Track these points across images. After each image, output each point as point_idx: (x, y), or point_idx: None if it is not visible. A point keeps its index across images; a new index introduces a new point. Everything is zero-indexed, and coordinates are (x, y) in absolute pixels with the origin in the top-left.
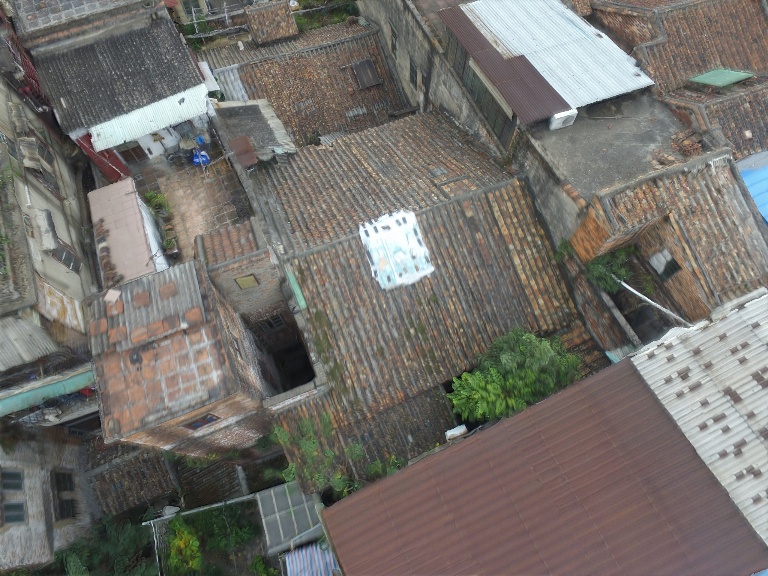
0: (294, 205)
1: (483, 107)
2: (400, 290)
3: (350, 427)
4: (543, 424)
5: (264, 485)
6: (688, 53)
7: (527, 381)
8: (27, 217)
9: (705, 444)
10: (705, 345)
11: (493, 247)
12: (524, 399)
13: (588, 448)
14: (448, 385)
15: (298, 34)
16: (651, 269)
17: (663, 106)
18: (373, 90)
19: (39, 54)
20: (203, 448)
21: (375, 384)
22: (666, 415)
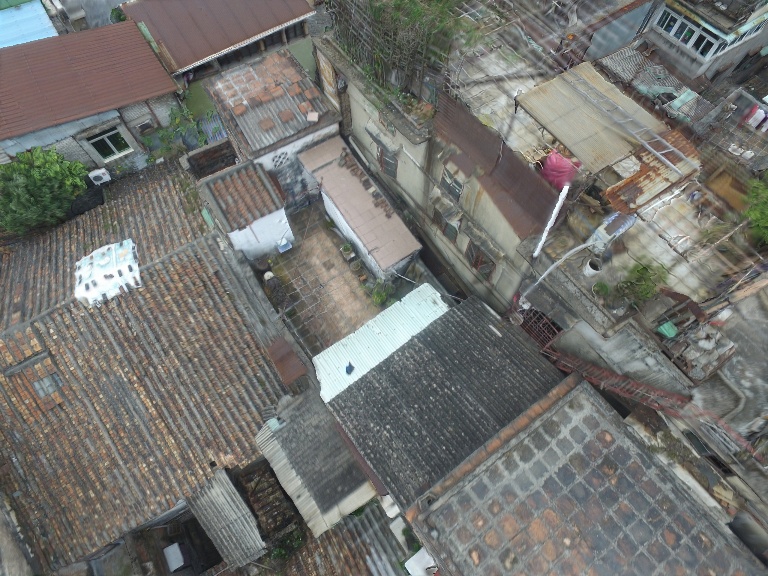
0: (231, 324)
1: None
2: None
3: None
4: (1, 129)
5: None
6: None
7: (8, 164)
8: None
9: None
10: None
11: (8, 296)
12: None
13: None
14: None
15: None
16: None
17: None
18: None
19: None
20: None
21: None
22: None
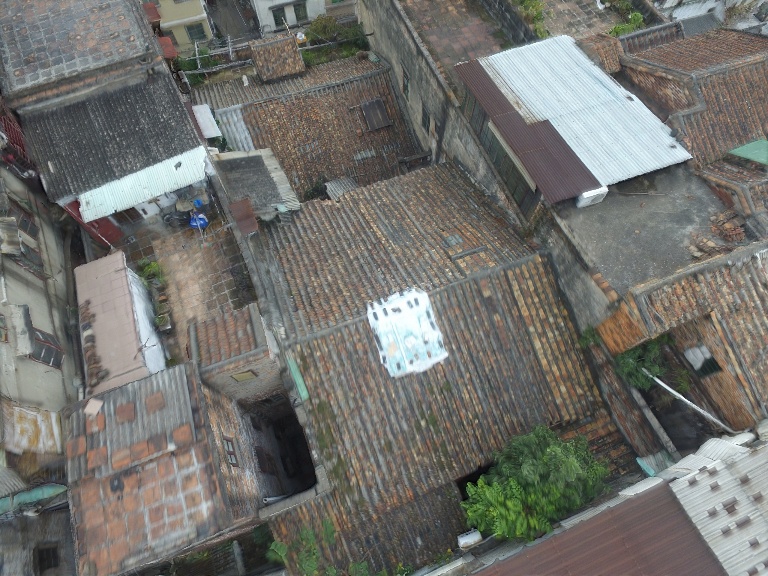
0: (297, 275)
1: (502, 170)
2: (410, 377)
3: (354, 529)
4: (570, 557)
5: (261, 561)
6: (728, 122)
7: (551, 498)
8: (1, 317)
9: None
10: (754, 472)
11: (512, 329)
12: (547, 516)
13: None
14: (461, 481)
15: (305, 70)
16: (686, 362)
17: (701, 181)
18: (383, 132)
19: (26, 113)
20: (194, 549)
21: (382, 482)
22: (710, 555)
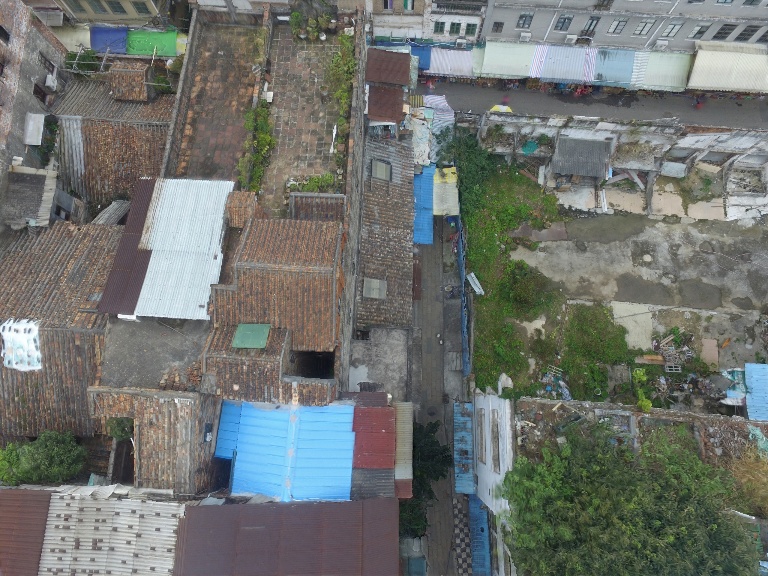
0: (2, 277)
1: None
2: None
3: None
4: None
5: None
6: (253, 303)
7: None
8: None
9: (46, 560)
10: (87, 509)
11: (87, 370)
12: (19, 478)
13: (3, 527)
14: (31, 439)
15: (154, 97)
16: None
17: None
18: None
19: None
20: None
21: None
22: (43, 534)
